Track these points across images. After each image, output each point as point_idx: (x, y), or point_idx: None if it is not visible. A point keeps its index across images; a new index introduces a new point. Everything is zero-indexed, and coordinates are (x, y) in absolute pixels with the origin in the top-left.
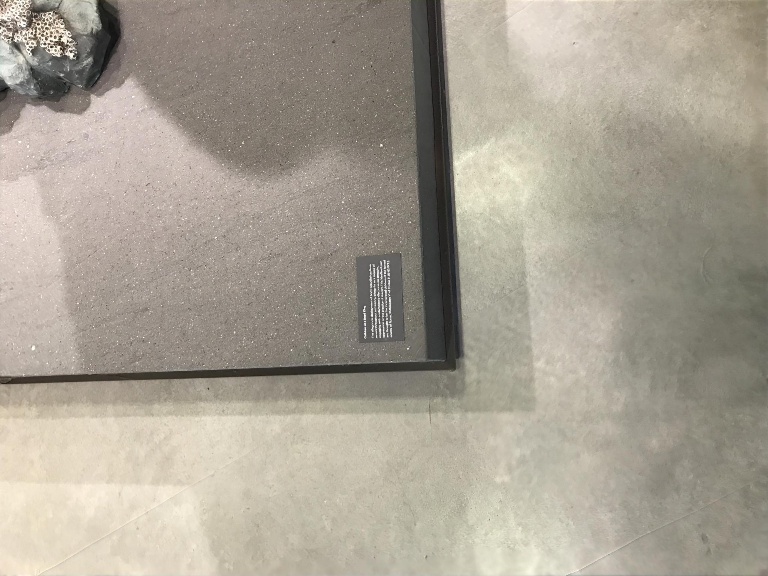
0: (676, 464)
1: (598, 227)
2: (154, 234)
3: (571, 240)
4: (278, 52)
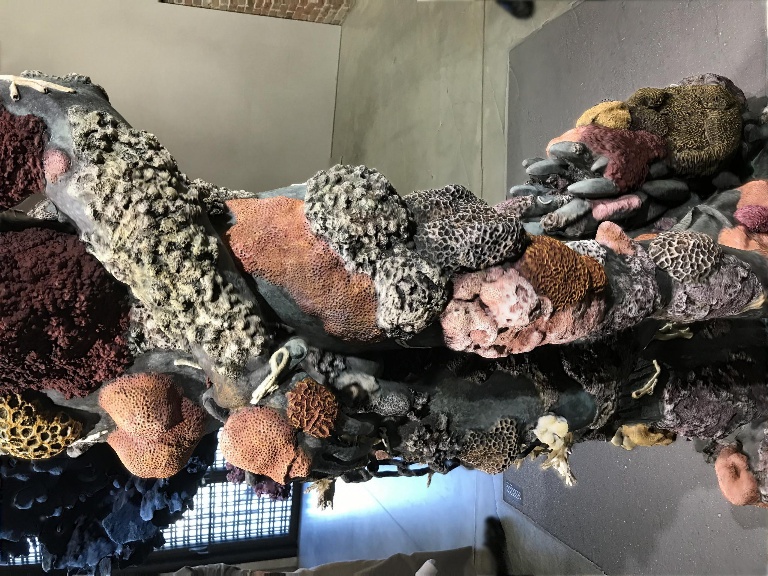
0: (517, 555)
1: (563, 575)
2: None
3: (560, 562)
4: (574, 488)
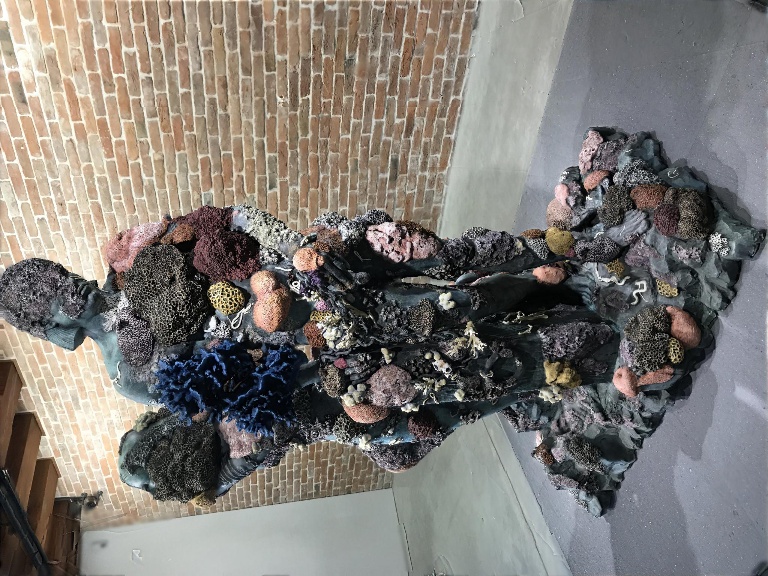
0: None
1: None
2: (595, 570)
3: None
4: None
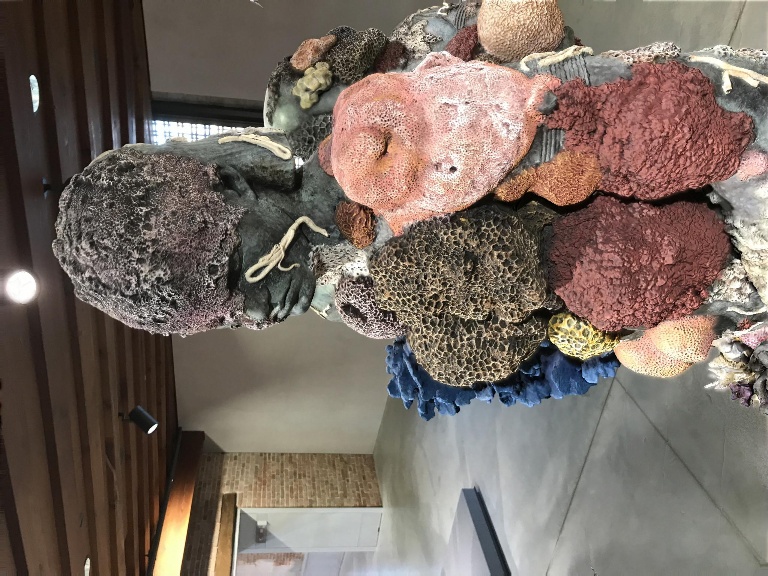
0: None
1: None
2: None
3: None
4: None
